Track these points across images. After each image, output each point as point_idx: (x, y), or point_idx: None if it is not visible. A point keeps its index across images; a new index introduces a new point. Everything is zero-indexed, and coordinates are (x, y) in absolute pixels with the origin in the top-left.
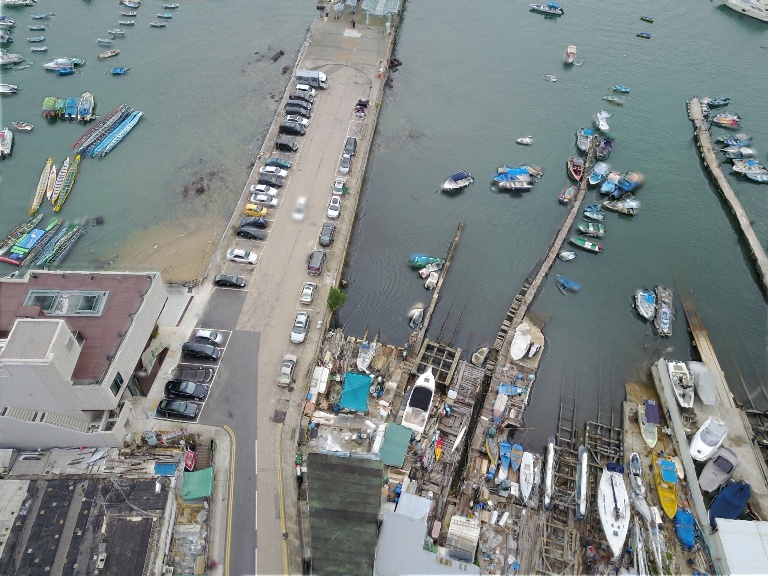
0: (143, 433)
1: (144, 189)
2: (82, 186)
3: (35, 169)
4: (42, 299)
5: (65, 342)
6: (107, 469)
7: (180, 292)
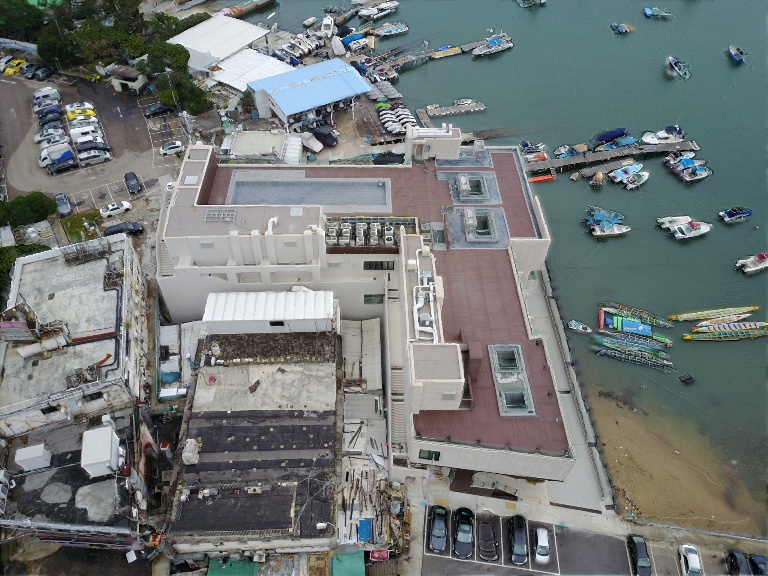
0: (405, 497)
1: (765, 415)
2: (735, 350)
3: (736, 300)
4: (511, 358)
5: (446, 392)
6: (365, 473)
7: (602, 496)
